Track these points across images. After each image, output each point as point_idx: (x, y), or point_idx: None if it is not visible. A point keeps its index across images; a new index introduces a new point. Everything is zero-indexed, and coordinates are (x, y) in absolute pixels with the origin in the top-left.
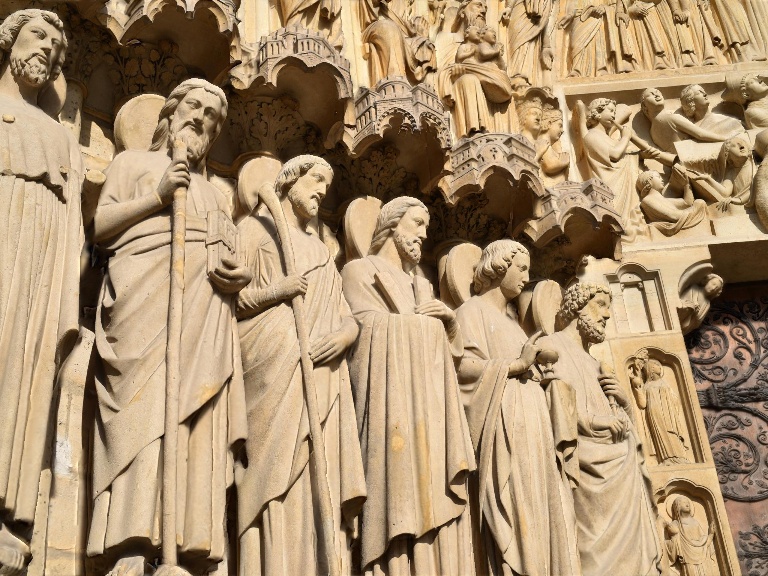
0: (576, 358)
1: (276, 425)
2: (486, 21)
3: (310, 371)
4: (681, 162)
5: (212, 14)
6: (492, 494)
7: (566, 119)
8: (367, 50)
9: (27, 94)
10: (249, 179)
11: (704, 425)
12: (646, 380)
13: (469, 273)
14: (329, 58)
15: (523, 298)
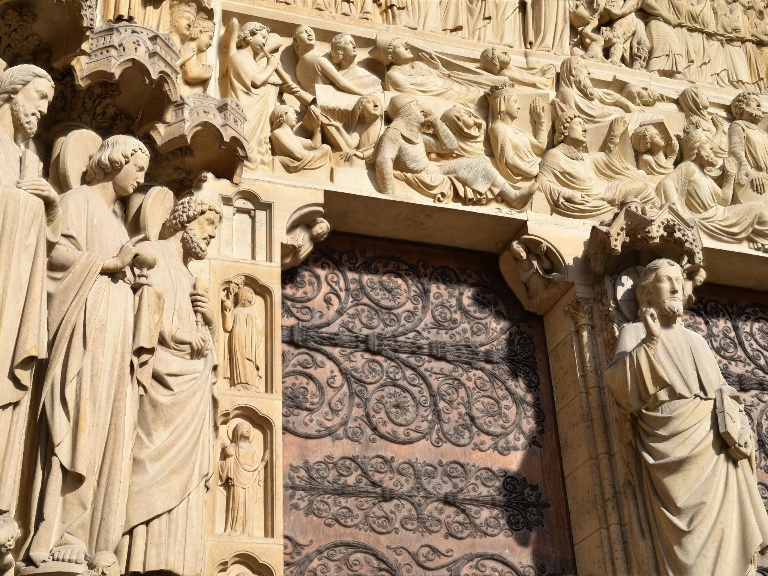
0: (173, 269)
1: None
2: None
3: None
4: (318, 105)
5: None
6: (57, 386)
7: (218, 33)
8: None
9: None
10: None
11: (281, 358)
12: (237, 305)
13: (84, 160)
14: None
15: (134, 199)
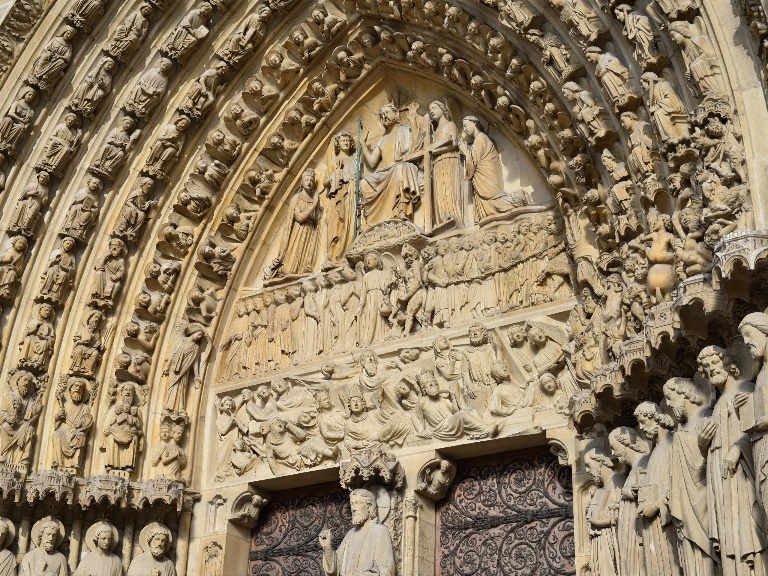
0: (141, 568)
1: None
2: (156, 378)
3: None
4: (248, 434)
5: None
6: None
7: (213, 409)
8: None
9: None
10: None
11: None
12: None
13: None
14: None
15: None
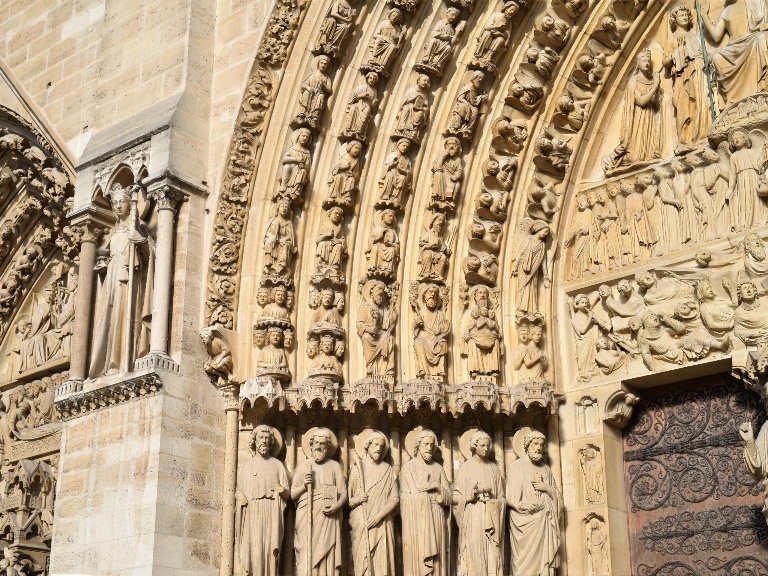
0: (522, 474)
1: None
2: (504, 279)
3: (366, 533)
4: (613, 331)
5: (320, 401)
6: None
7: (565, 308)
8: None
9: (264, 456)
10: (358, 444)
11: (606, 484)
12: None
13: None
14: None
15: None
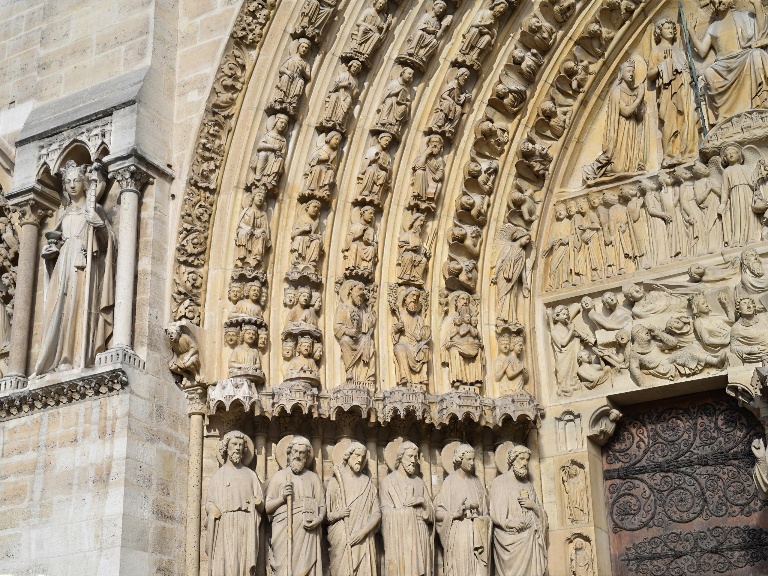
0: (507, 490)
1: (340, 571)
2: (483, 286)
3: (349, 550)
4: (598, 344)
5: (300, 407)
6: None
7: (543, 320)
8: (394, 360)
9: (236, 465)
10: (335, 455)
11: (592, 503)
12: None
13: None
14: (358, 398)
15: None
